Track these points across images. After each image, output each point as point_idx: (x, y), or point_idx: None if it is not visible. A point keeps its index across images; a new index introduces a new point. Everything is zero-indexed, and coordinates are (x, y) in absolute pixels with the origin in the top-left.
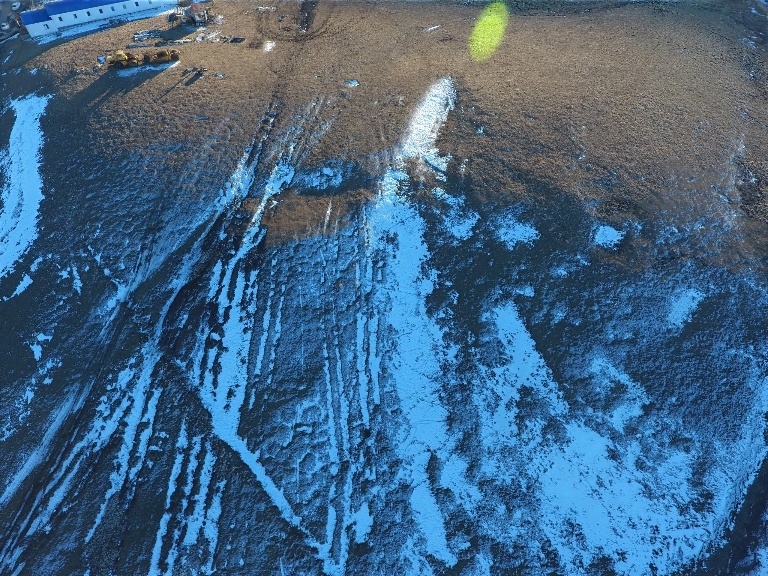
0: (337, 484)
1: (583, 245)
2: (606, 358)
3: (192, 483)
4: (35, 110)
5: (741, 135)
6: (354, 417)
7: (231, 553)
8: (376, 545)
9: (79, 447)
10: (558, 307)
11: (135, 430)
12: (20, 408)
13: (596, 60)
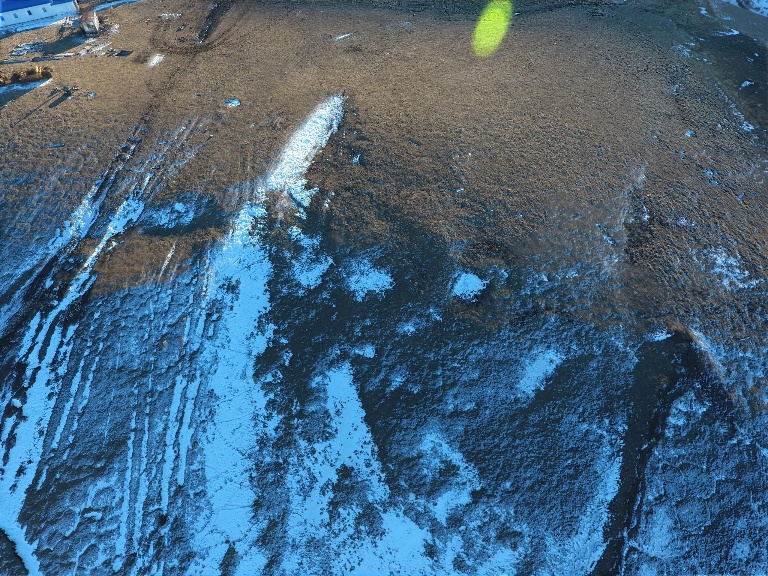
0: None
1: (439, 296)
2: (440, 433)
3: None
4: None
5: (644, 163)
6: (151, 501)
7: None
8: None
9: None
10: (398, 371)
11: None
12: None
13: (504, 74)
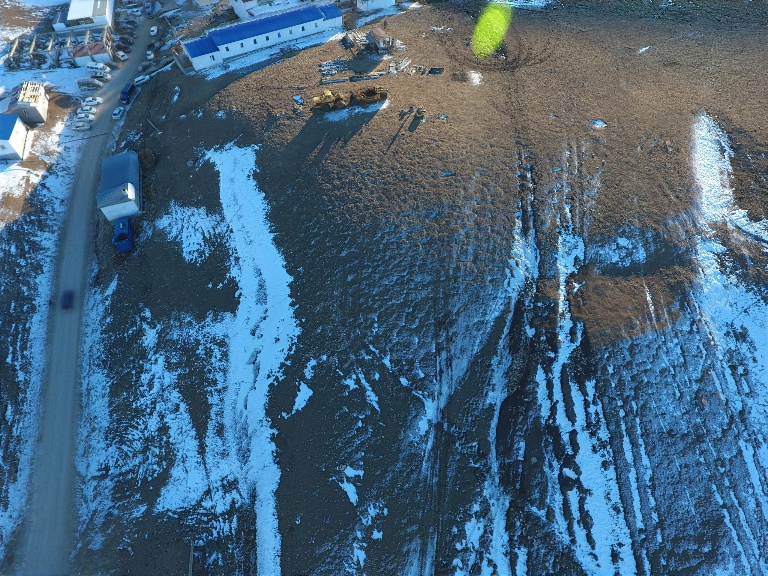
0: None
1: None
2: None
3: None
4: (243, 164)
5: None
6: None
7: None
8: None
9: None
10: None
11: None
12: (353, 573)
13: None
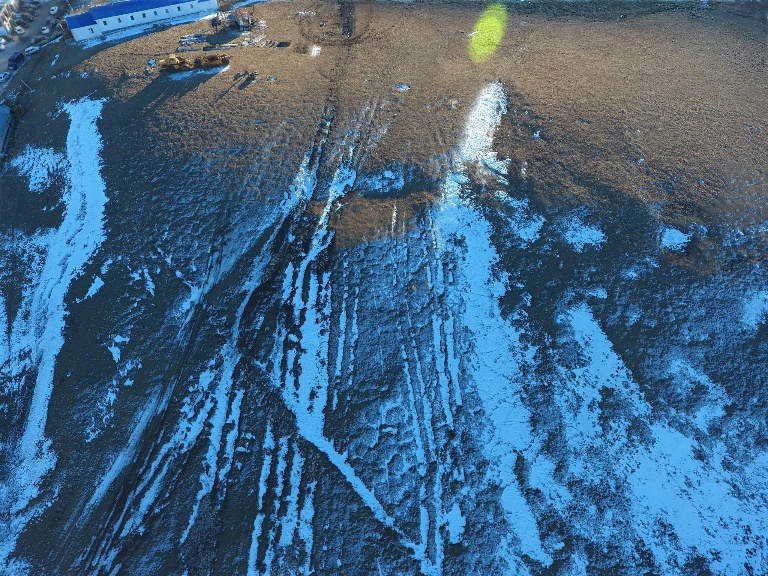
0: (427, 485)
1: (651, 247)
2: (684, 359)
3: (283, 484)
4: (90, 113)
5: None
6: (438, 418)
7: (328, 554)
8: (471, 545)
9: (166, 448)
10: (632, 309)
11: (221, 431)
12: (103, 409)
13: (641, 65)
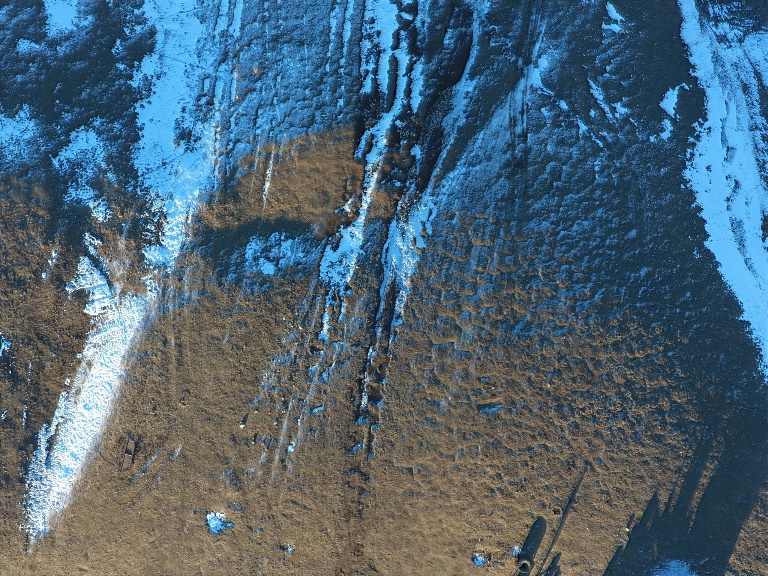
0: None
1: None
2: None
3: None
4: None
5: None
6: None
7: None
8: None
9: None
10: None
11: None
12: None
13: None
